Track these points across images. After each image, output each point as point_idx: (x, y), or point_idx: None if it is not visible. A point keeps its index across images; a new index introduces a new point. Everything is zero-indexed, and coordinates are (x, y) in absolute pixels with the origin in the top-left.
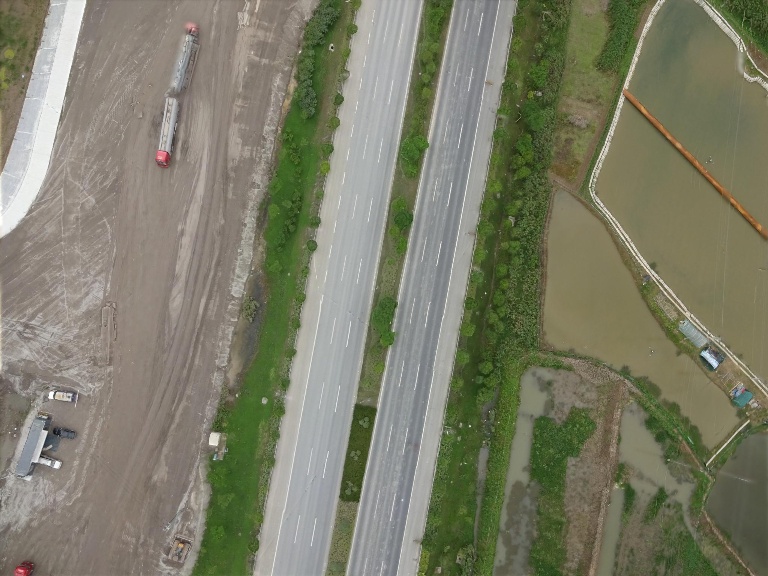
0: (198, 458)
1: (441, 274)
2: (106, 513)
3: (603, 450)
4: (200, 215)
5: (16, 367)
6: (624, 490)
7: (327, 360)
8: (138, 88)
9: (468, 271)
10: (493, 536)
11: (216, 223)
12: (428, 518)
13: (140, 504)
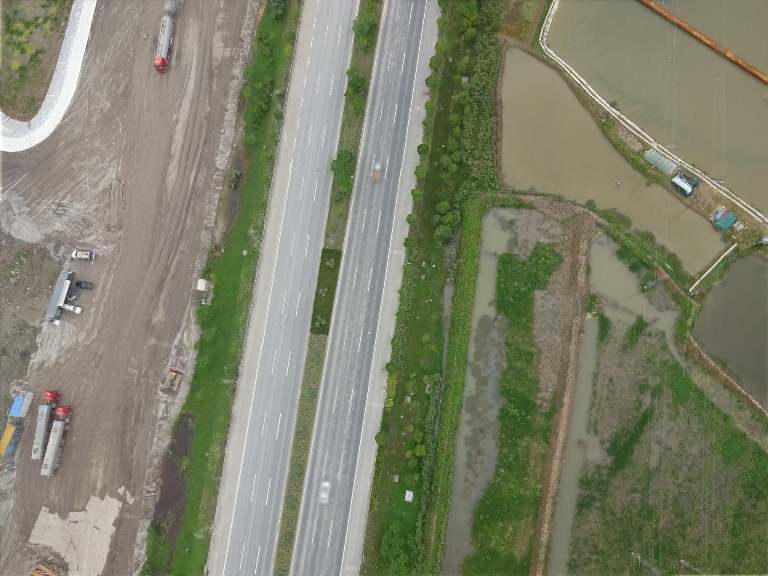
0: (189, 302)
1: (398, 131)
2: (116, 350)
3: (572, 281)
4: (190, 106)
5: (51, 237)
6: (598, 319)
7: (297, 214)
8: (143, 16)
9: (423, 126)
10: (460, 366)
11: (203, 111)
12: (393, 347)
13: (142, 342)
